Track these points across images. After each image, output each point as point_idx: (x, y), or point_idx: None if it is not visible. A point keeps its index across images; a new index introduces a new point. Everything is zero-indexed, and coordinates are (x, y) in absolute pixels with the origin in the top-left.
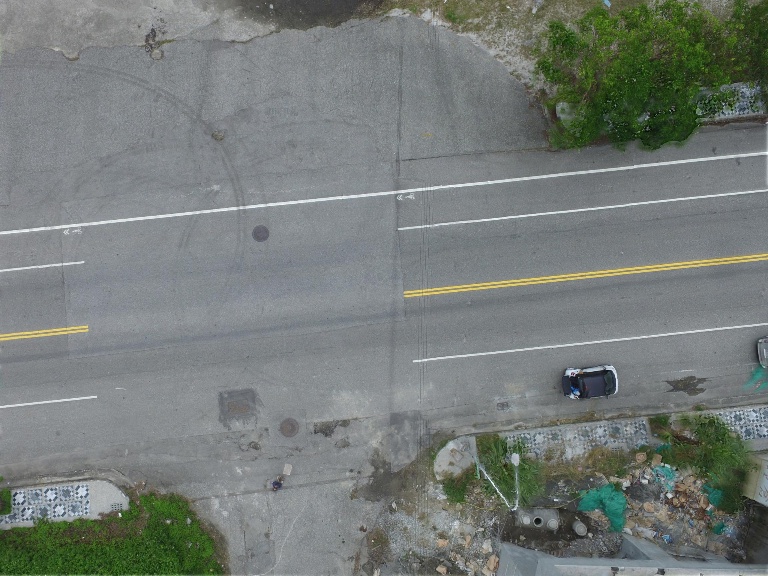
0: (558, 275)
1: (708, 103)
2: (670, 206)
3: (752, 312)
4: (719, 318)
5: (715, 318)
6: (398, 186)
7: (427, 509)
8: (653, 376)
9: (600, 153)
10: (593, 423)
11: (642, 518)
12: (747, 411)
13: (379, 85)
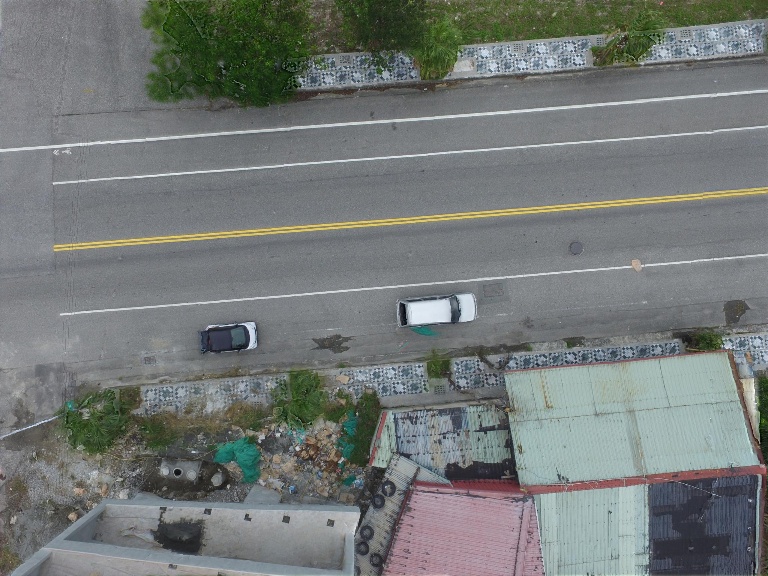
0: (209, 233)
1: (368, 68)
2: (324, 168)
3: (398, 273)
4: (366, 279)
5: (361, 278)
6: (56, 141)
7: (67, 459)
8: (299, 334)
9: (259, 114)
10: (236, 378)
11: (271, 469)
12: (386, 369)
13: (47, 40)
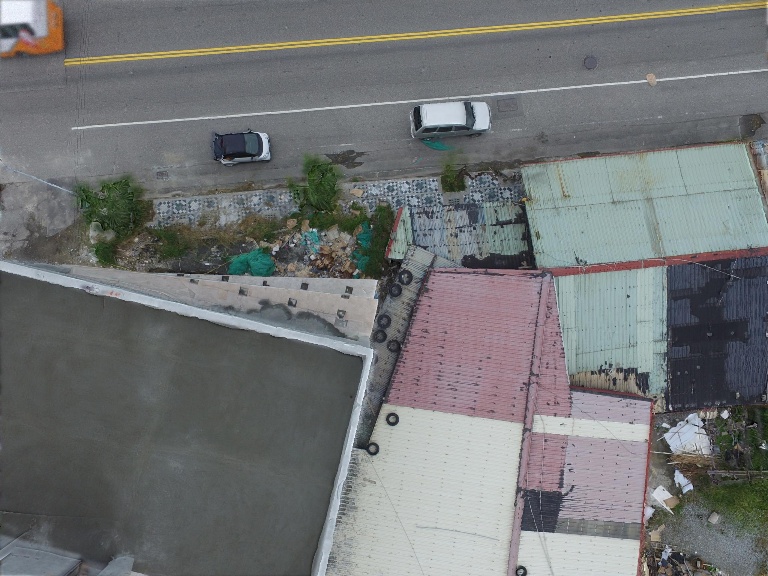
0: (221, 47)
1: None
2: None
3: (411, 88)
4: (379, 93)
5: (374, 93)
6: None
7: None
8: (313, 149)
9: None
10: (249, 192)
11: None
12: (400, 183)
13: None
